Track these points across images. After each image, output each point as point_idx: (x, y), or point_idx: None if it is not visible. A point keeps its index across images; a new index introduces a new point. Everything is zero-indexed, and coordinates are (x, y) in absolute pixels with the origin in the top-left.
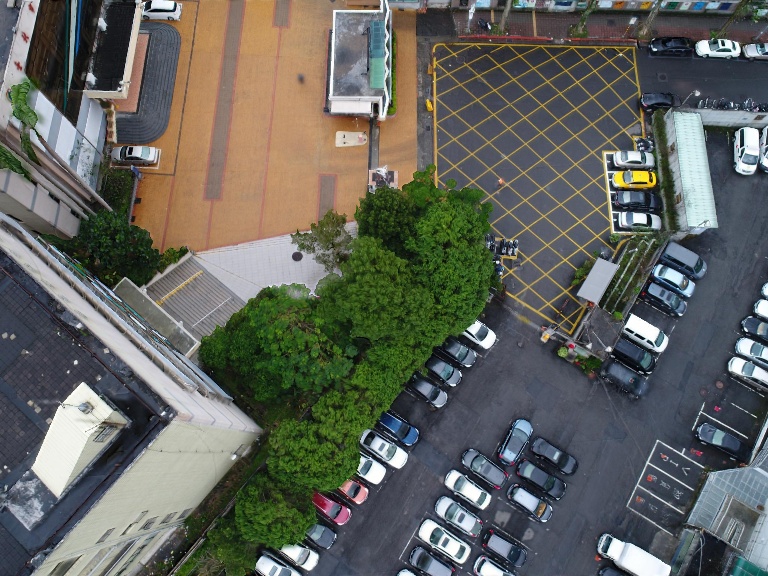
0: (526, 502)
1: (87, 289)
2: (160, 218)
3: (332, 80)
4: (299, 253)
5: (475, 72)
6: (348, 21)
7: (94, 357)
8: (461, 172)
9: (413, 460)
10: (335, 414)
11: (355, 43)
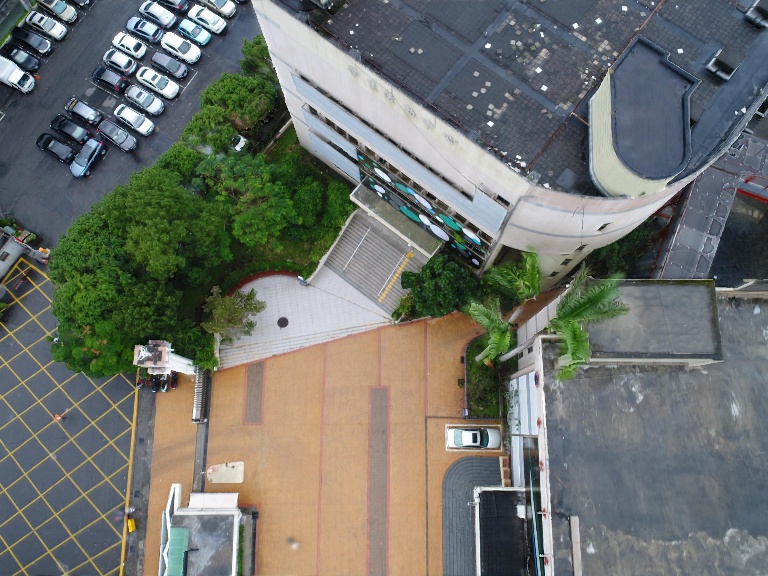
0: (84, 108)
1: (403, 159)
2: (434, 362)
3: (235, 539)
4: (281, 326)
5: None
6: None
7: None
8: (105, 435)
9: None
10: (210, 123)
11: None
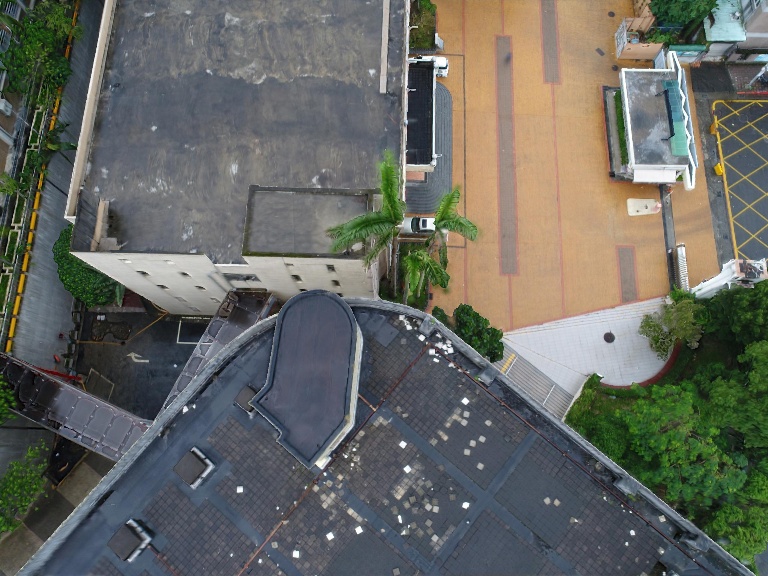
0: None
1: None
2: (458, 295)
3: (632, 146)
4: (610, 334)
5: (761, 132)
6: (638, 81)
7: (650, 526)
8: (761, 242)
9: (757, 560)
10: (744, 534)
11: (649, 105)
